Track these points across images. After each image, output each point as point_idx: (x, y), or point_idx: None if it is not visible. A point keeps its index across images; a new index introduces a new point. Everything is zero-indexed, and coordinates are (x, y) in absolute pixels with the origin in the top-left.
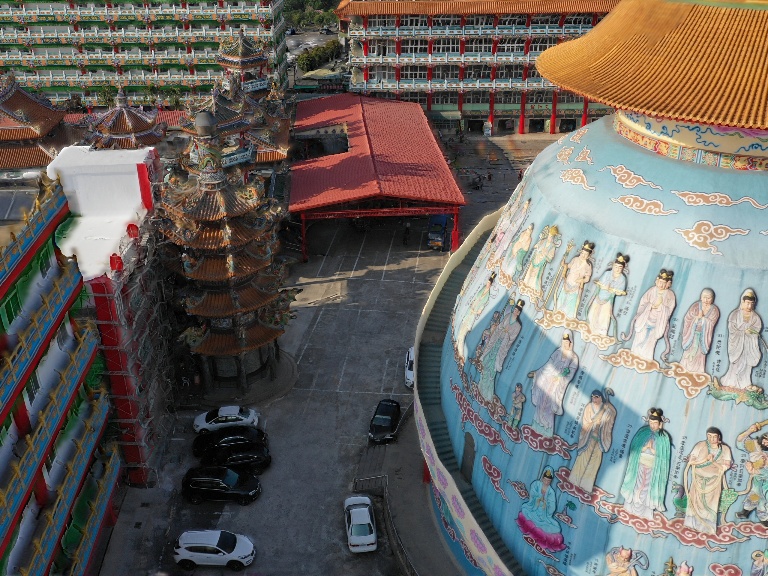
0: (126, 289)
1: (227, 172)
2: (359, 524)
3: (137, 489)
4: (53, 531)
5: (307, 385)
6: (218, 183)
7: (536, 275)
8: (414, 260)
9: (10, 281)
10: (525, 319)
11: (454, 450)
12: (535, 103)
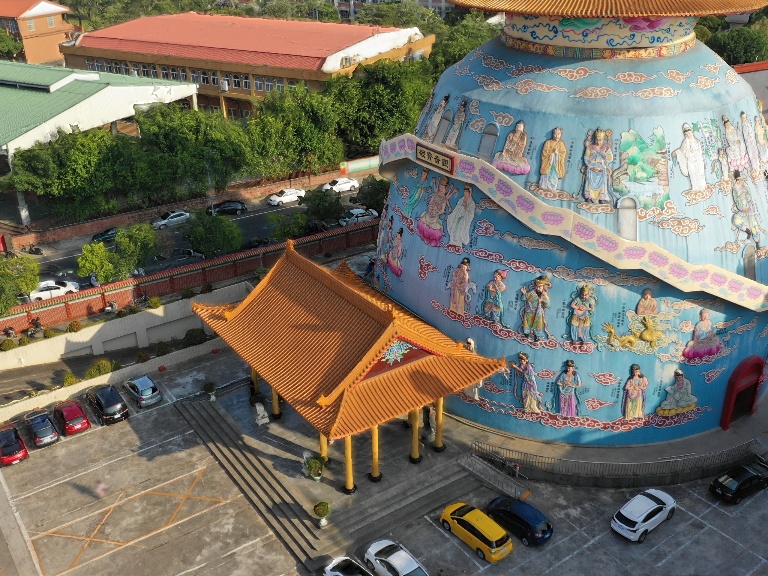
0: None
1: None
2: None
3: None
4: None
5: None
6: None
7: None
8: None
9: None
10: None
11: None
12: None
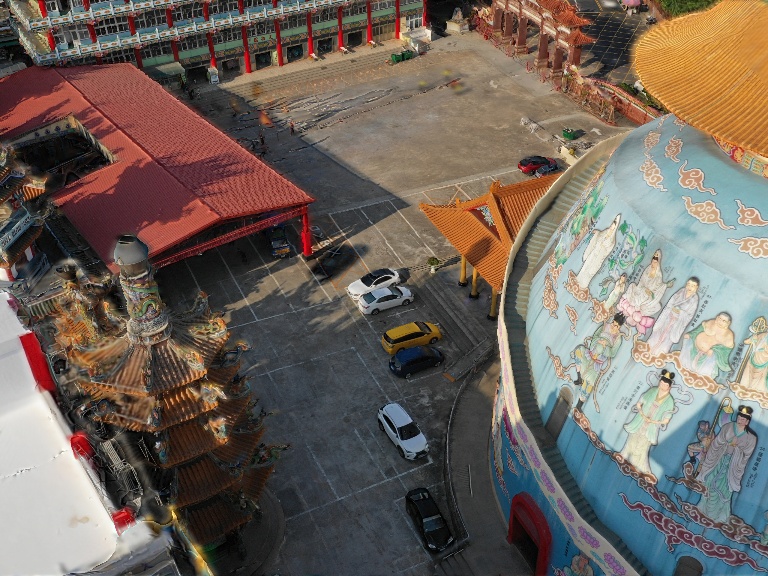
0: None
1: (15, 251)
2: None
3: None
4: None
5: (298, 507)
6: (165, 328)
7: (764, 377)
8: (270, 280)
9: None
10: (760, 428)
11: (649, 570)
12: (257, 35)
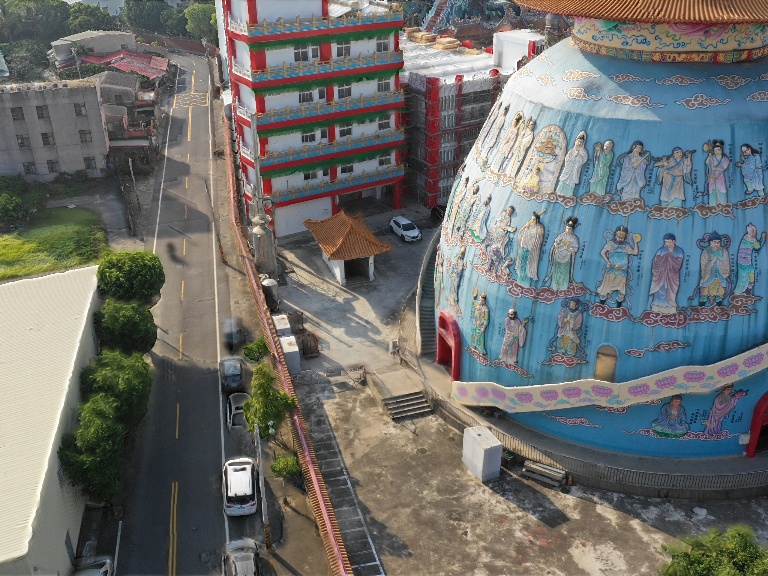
0: (461, 96)
1: None
2: None
3: (424, 206)
4: (320, 151)
5: None
6: None
7: None
8: None
9: (334, 33)
10: None
11: None
12: None
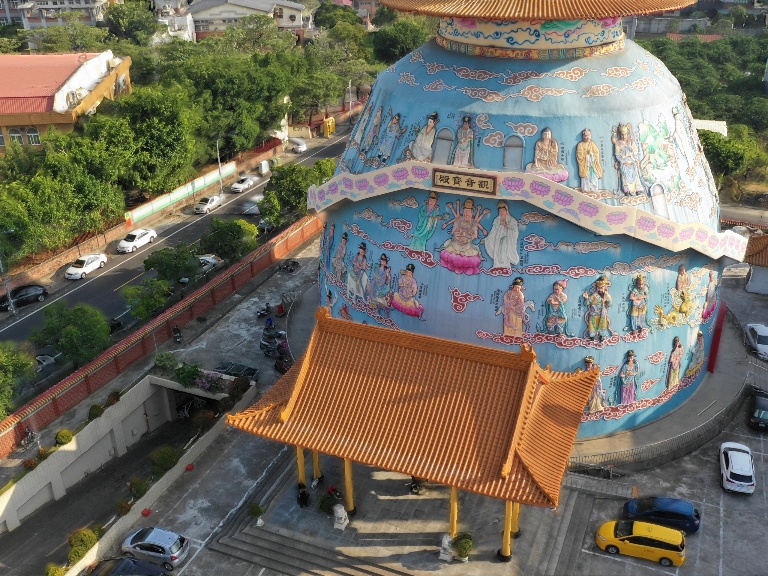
0: None
1: None
2: (762, 326)
3: None
4: None
5: None
6: None
7: None
8: None
9: None
10: None
11: None
12: None
